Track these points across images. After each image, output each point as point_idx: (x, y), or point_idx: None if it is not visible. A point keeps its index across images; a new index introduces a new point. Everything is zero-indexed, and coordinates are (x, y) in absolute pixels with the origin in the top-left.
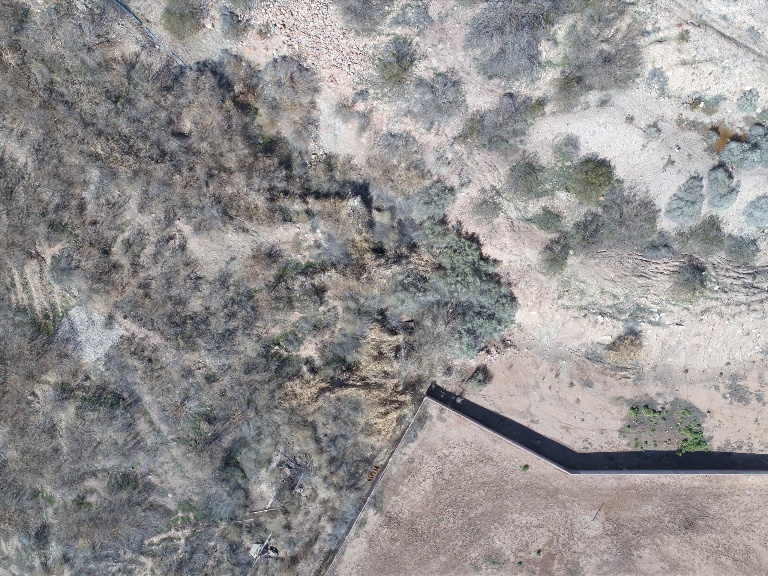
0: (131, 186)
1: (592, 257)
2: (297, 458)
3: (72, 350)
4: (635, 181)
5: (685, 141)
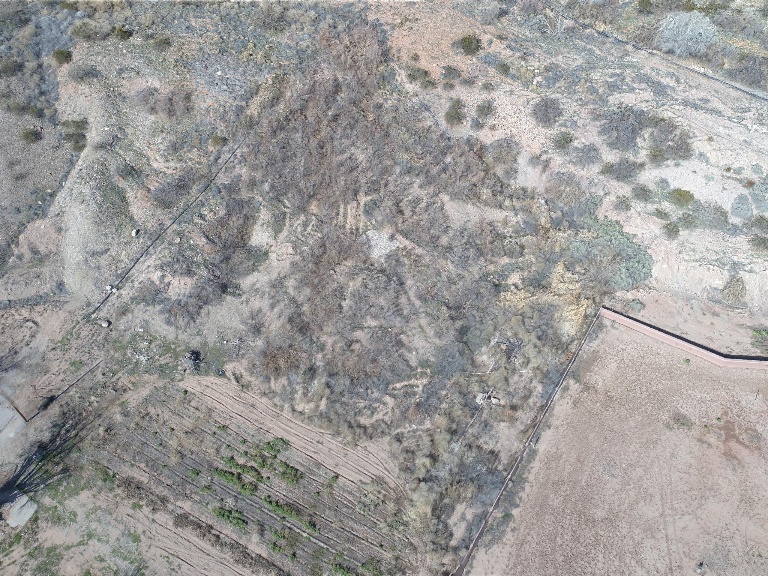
0: (416, 177)
1: (694, 232)
2: (510, 339)
3: (366, 248)
4: (707, 199)
5: None
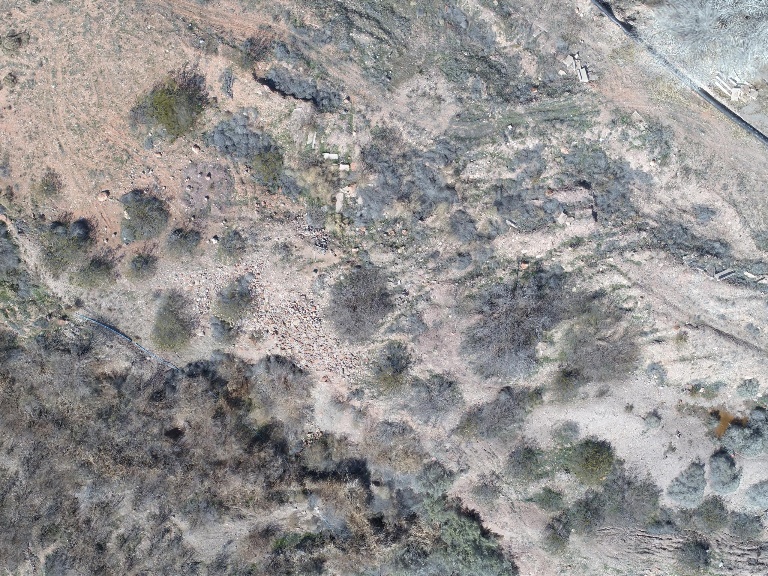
0: None
1: (594, 535)
2: None
3: None
4: (636, 463)
5: (686, 427)
